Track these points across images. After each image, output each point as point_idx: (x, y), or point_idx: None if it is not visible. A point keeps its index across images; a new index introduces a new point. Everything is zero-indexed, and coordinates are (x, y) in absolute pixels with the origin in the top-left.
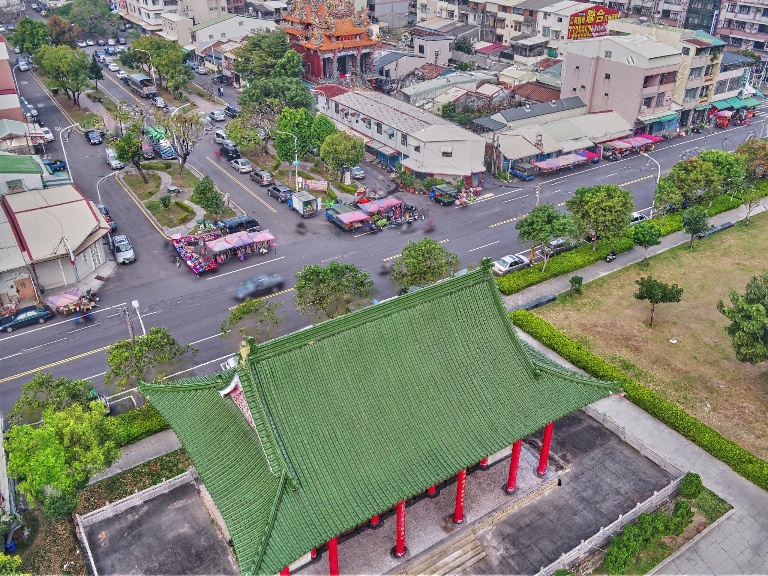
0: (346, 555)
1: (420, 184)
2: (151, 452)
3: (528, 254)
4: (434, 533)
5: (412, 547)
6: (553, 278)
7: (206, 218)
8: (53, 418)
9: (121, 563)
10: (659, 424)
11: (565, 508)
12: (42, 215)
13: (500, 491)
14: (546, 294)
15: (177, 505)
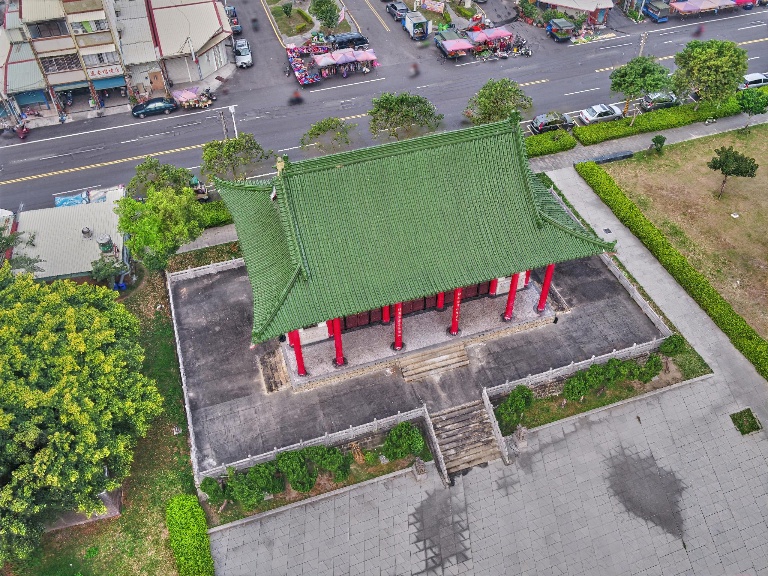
0: (356, 340)
1: (542, 15)
2: (233, 236)
3: (624, 105)
4: (431, 338)
5: (409, 345)
6: (639, 134)
7: (322, 30)
8: (154, 196)
9: (193, 312)
10: (680, 290)
11: (552, 342)
12: (175, 13)
13: (498, 317)
14: (625, 150)
15: (241, 279)
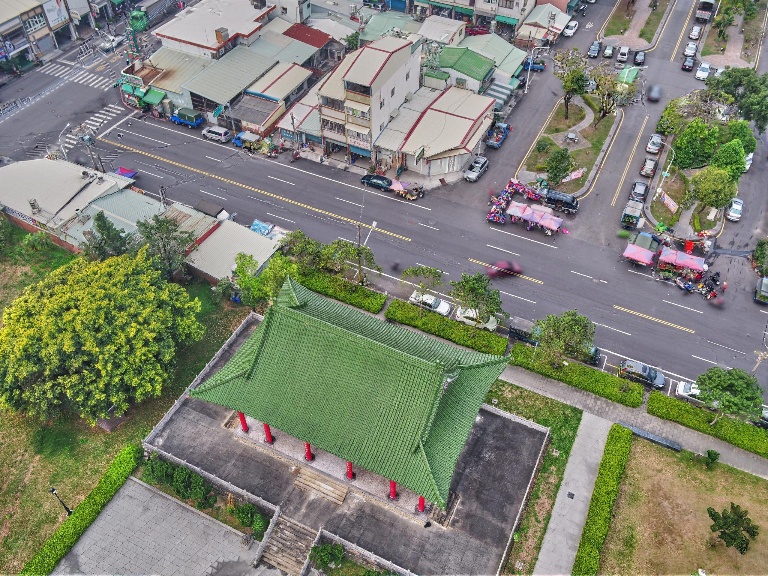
0: None
1: None
2: None
3: None
4: (333, 469)
5: (317, 462)
6: (714, 437)
7: None
8: None
9: None
10: None
11: (407, 537)
12: (440, 119)
13: (388, 491)
14: (681, 441)
15: None
